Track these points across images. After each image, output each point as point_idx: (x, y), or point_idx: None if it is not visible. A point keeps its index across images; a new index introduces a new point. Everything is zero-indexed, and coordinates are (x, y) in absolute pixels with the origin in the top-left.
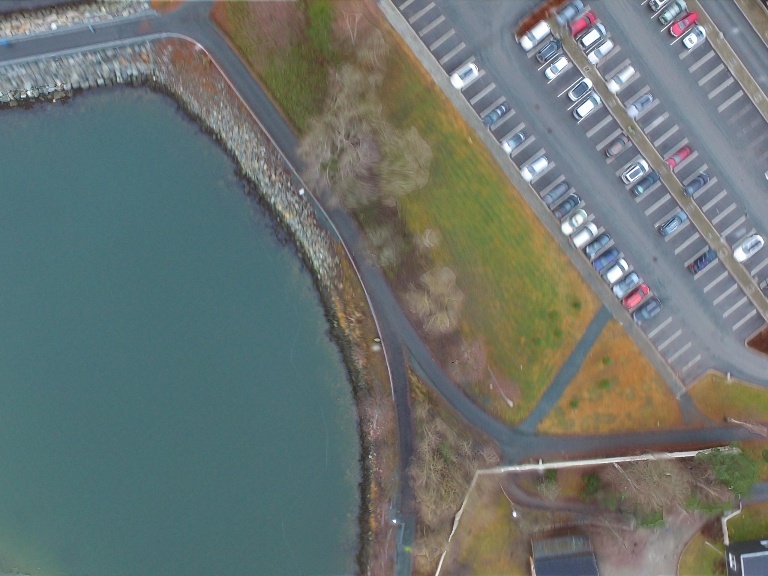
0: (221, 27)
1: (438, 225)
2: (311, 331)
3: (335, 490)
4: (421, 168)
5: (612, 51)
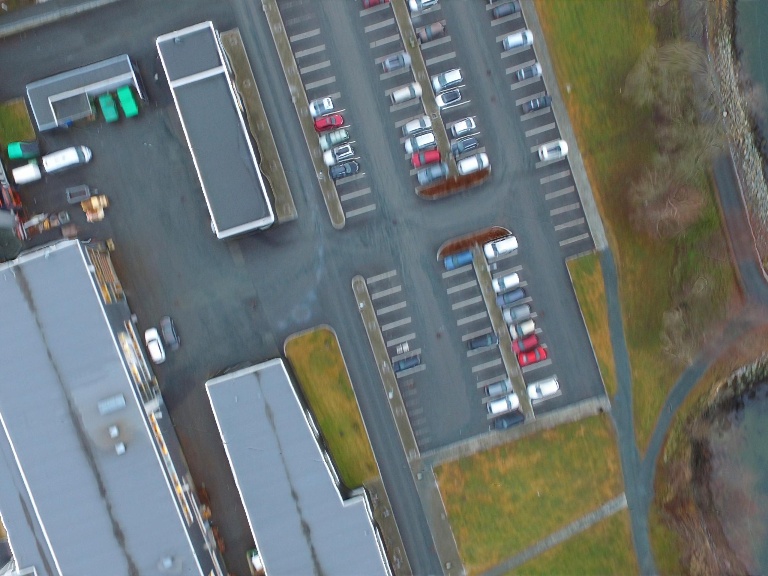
0: (740, 290)
1: (629, 22)
2: None
3: None
4: (648, 63)
5: None
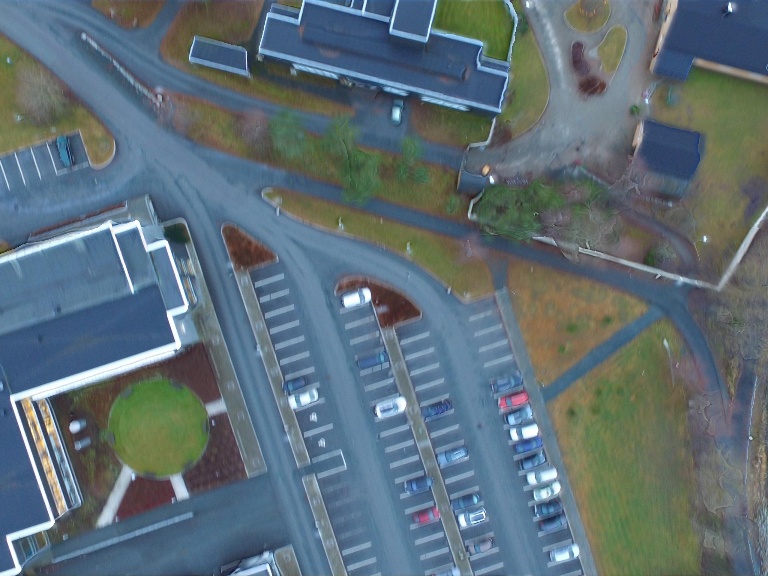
0: None
1: (673, 533)
2: None
3: None
4: None
5: None
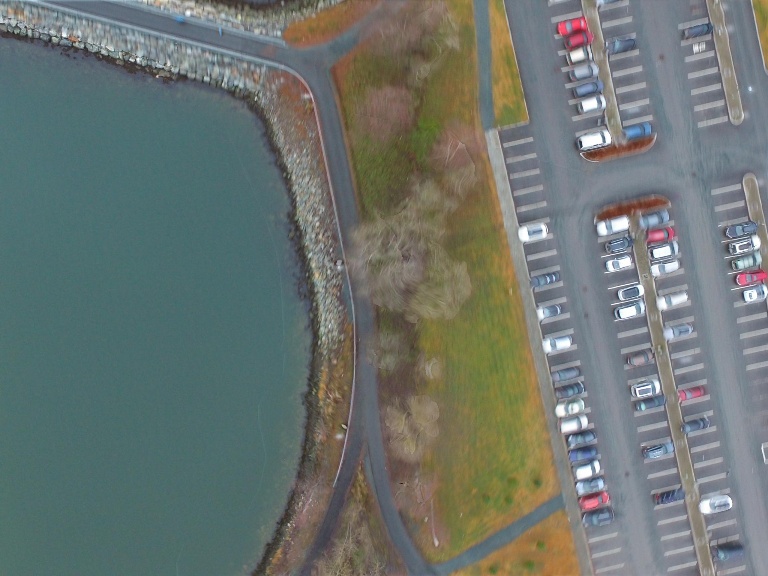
0: (337, 83)
1: (447, 353)
2: (289, 386)
3: (244, 538)
4: (454, 302)
5: (676, 271)
